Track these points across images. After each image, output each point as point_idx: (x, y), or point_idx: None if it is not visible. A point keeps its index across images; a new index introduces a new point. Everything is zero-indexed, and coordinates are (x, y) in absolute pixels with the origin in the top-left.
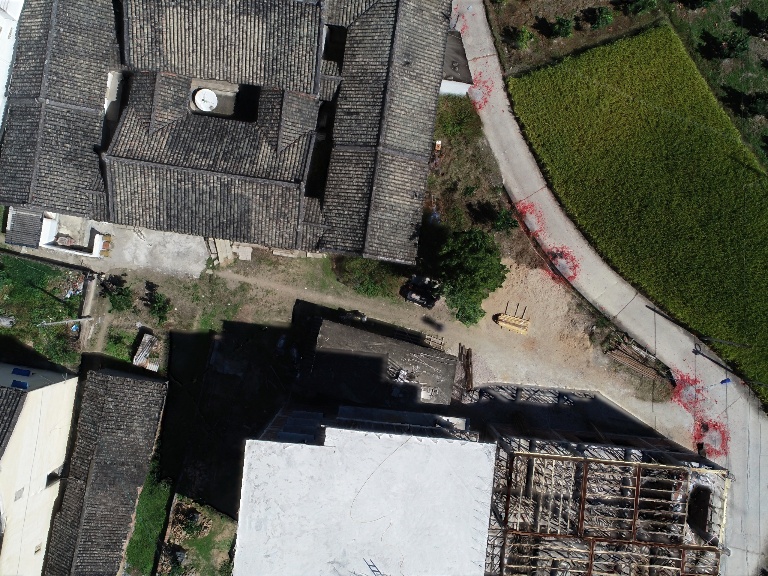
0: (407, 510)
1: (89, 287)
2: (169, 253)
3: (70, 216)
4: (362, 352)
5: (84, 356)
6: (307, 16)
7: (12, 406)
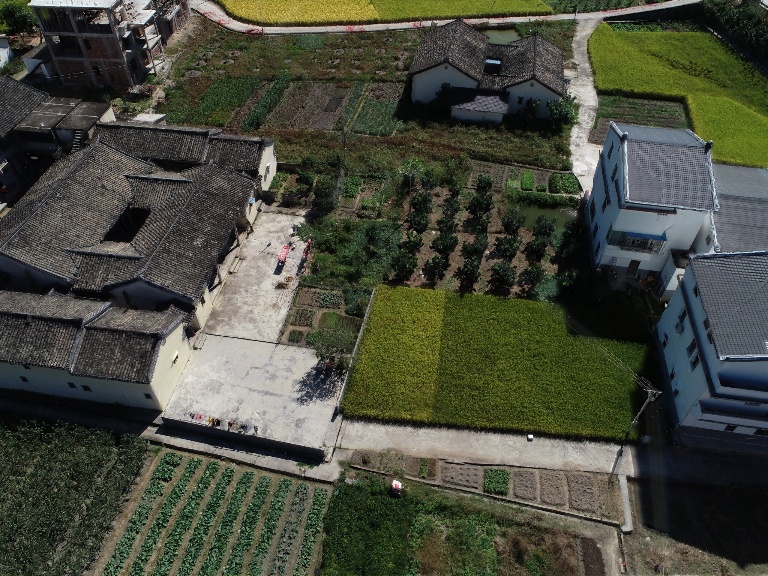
0: None
1: None
2: None
3: None
4: (42, 49)
5: None
6: None
7: None
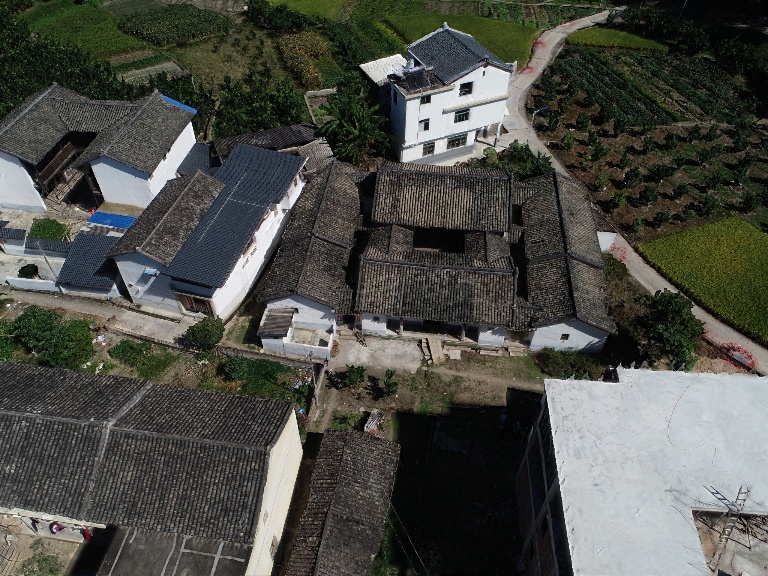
0: (727, 436)
1: (321, 374)
2: (388, 355)
3: (303, 332)
4: None
5: (309, 435)
6: (501, 187)
7: (282, 410)
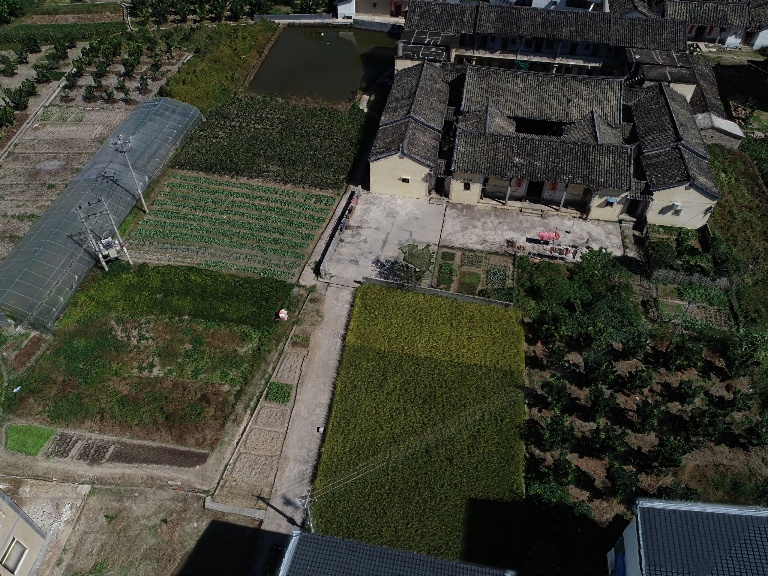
0: None
1: None
2: None
3: None
4: None
5: None
6: None
7: None
